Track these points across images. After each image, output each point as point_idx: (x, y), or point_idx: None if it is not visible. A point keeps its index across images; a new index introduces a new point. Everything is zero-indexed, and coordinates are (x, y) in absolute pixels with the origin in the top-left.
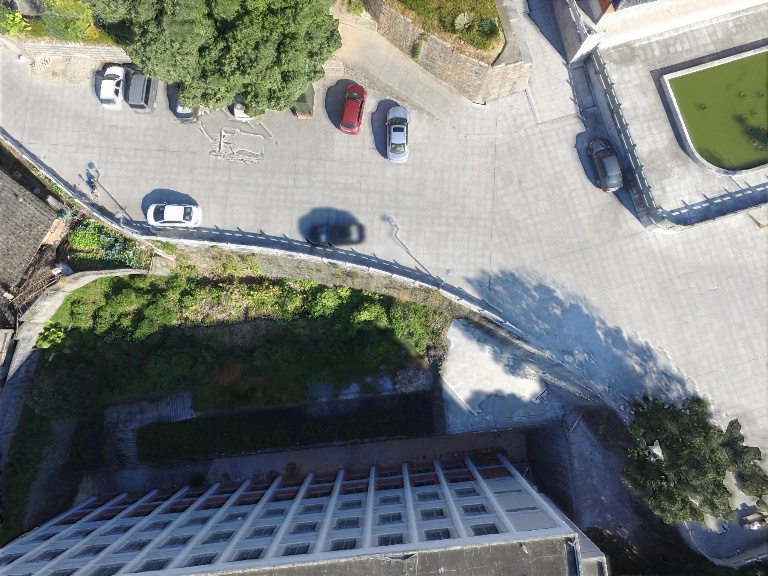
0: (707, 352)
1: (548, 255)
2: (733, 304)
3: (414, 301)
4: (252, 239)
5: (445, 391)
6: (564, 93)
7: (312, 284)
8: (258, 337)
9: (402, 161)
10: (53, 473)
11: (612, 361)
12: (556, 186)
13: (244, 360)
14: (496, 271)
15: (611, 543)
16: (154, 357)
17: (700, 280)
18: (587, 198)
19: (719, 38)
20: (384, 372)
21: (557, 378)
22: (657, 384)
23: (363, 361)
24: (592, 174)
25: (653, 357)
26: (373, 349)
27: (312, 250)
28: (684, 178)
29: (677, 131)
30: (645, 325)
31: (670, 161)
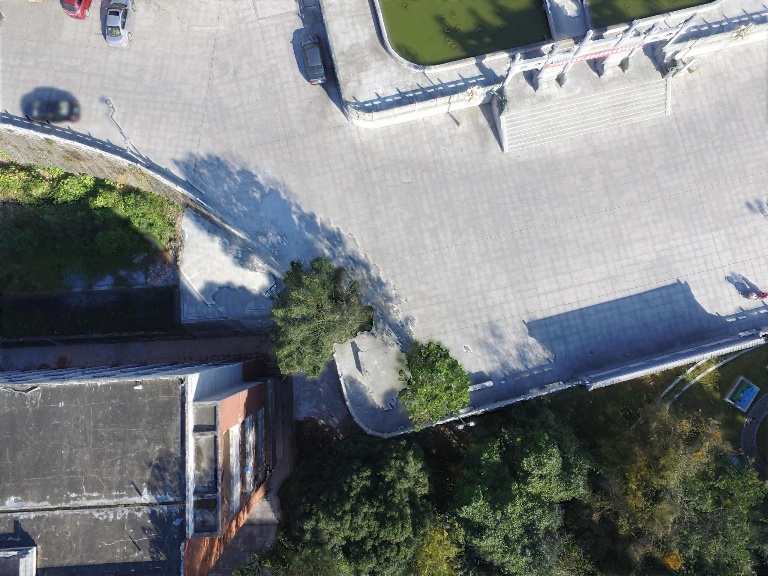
0: (395, 240)
1: (254, 142)
2: (424, 197)
3: (150, 190)
4: None
5: (181, 281)
6: None
7: (58, 171)
8: (7, 221)
9: (120, 45)
10: None
11: (303, 244)
12: (269, 78)
13: (0, 246)
14: (203, 155)
15: (324, 432)
16: None
17: (396, 173)
18: (297, 91)
19: None
20: (138, 266)
21: (271, 267)
22: (344, 268)
23: (99, 246)
24: (304, 68)
25: (343, 242)
26: (107, 234)
27: (30, 126)
28: (380, 72)
29: (378, 28)
30: (338, 212)
31: (369, 55)
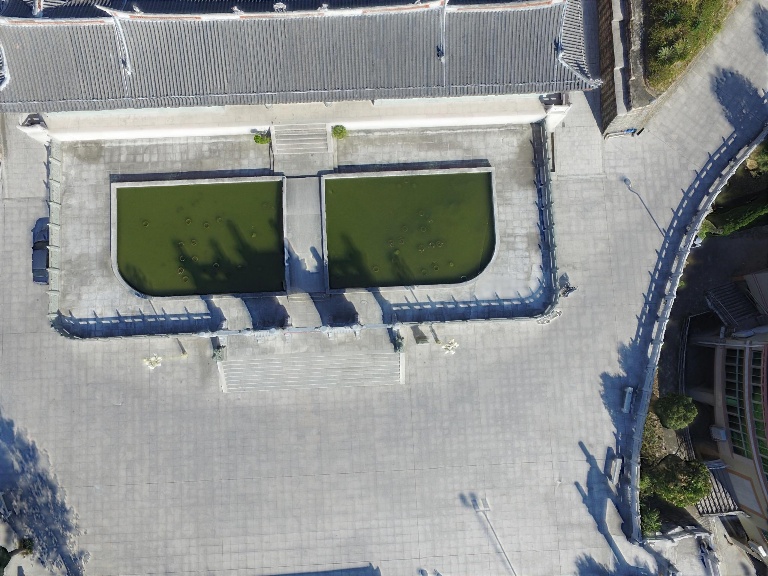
0: (89, 466)
1: None
2: (131, 425)
3: None
4: None
5: None
6: (38, 174)
7: None
8: None
9: None
10: None
11: None
12: None
13: None
14: None
15: None
16: None
17: (107, 393)
18: (26, 284)
19: (189, 158)
20: None
21: None
22: (29, 485)
23: None
24: None
25: (35, 458)
26: None
27: None
28: (104, 289)
29: None
30: (38, 424)
31: (96, 269)
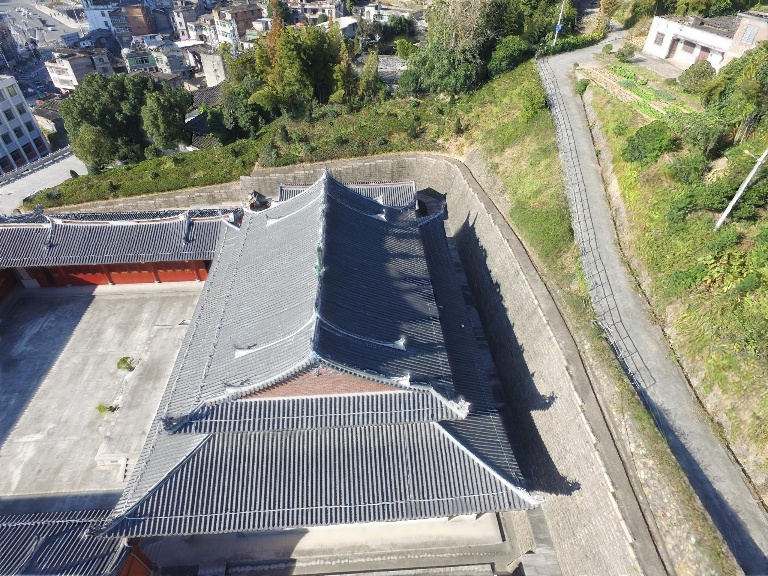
0: None
1: None
2: None
3: None
4: (59, 160)
5: None
6: None
7: None
8: None
9: None
10: None
11: None
12: None
13: None
14: None
15: None
16: None
17: None
18: None
19: None
20: None
21: None
22: None
23: None
24: None
25: None
26: None
27: None
28: None
29: None
30: None
31: None
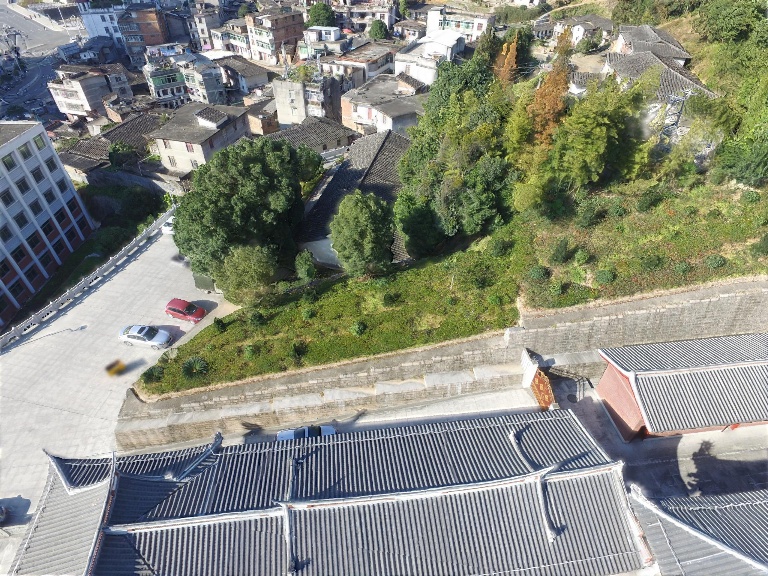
0: None
1: None
2: None
3: None
4: (136, 255)
5: None
6: None
7: None
8: None
9: None
10: (112, 208)
11: None
12: None
13: None
14: None
15: None
16: (122, 230)
17: None
18: None
19: None
20: None
21: None
22: None
23: None
24: None
25: None
26: None
27: (102, 282)
28: None
29: None
30: None
31: None
